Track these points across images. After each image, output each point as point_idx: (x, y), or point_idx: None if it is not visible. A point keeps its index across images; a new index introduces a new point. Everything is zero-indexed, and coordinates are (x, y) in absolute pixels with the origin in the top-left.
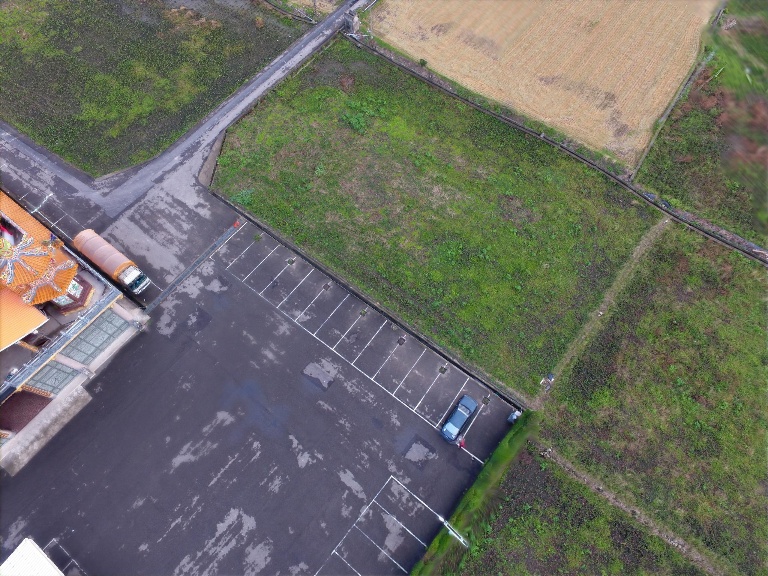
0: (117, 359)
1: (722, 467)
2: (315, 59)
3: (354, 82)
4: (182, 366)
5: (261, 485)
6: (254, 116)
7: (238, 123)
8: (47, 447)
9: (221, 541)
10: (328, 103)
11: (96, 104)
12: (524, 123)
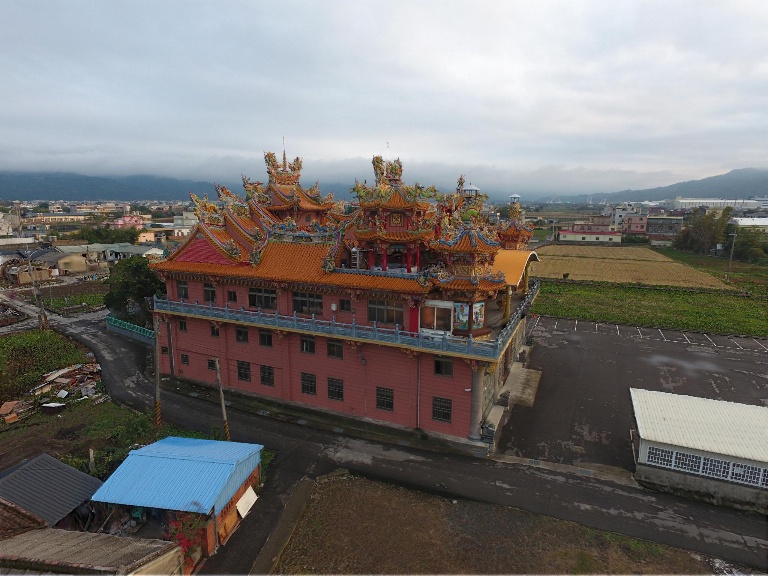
0: (533, 357)
1: None
2: None
3: None
4: None
5: (759, 388)
6: None
7: None
8: (540, 391)
9: None
10: None
11: None
12: (655, 287)
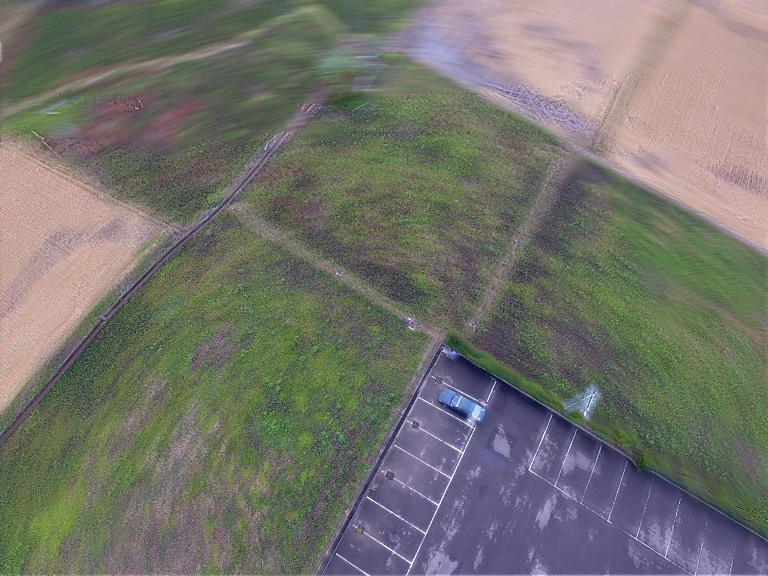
0: None
1: (456, 204)
2: None
3: None
4: None
5: None
6: None
7: None
8: None
9: None
10: None
11: None
12: (79, 339)
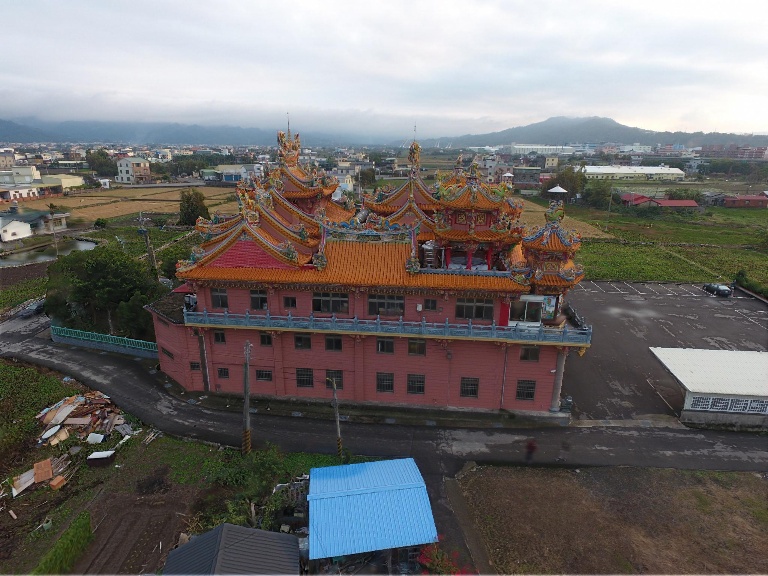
0: None
1: None
2: None
3: None
4: None
5: None
6: None
7: None
8: None
9: (725, 347)
10: None
11: None
12: None
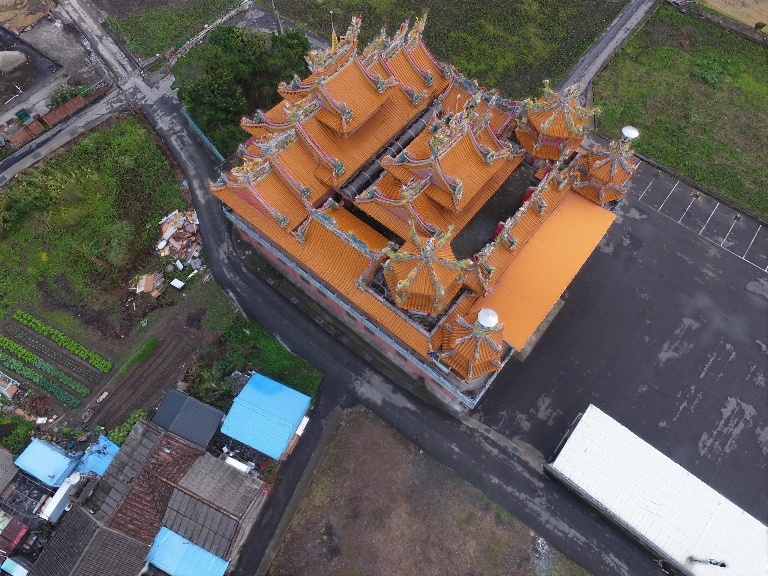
0: None
1: None
2: (647, 22)
3: (691, 43)
4: (634, 279)
5: (747, 380)
6: (610, 71)
7: (599, 76)
8: (543, 340)
9: (730, 423)
10: (674, 61)
11: (464, 57)
12: None
